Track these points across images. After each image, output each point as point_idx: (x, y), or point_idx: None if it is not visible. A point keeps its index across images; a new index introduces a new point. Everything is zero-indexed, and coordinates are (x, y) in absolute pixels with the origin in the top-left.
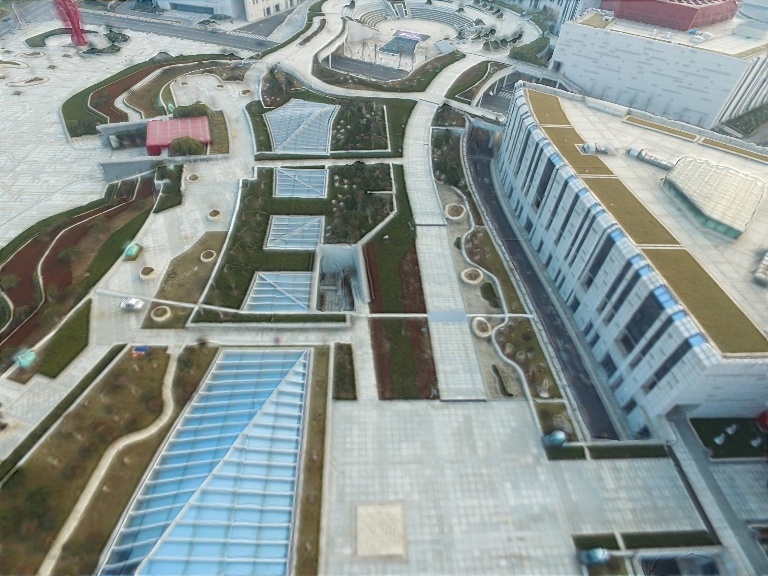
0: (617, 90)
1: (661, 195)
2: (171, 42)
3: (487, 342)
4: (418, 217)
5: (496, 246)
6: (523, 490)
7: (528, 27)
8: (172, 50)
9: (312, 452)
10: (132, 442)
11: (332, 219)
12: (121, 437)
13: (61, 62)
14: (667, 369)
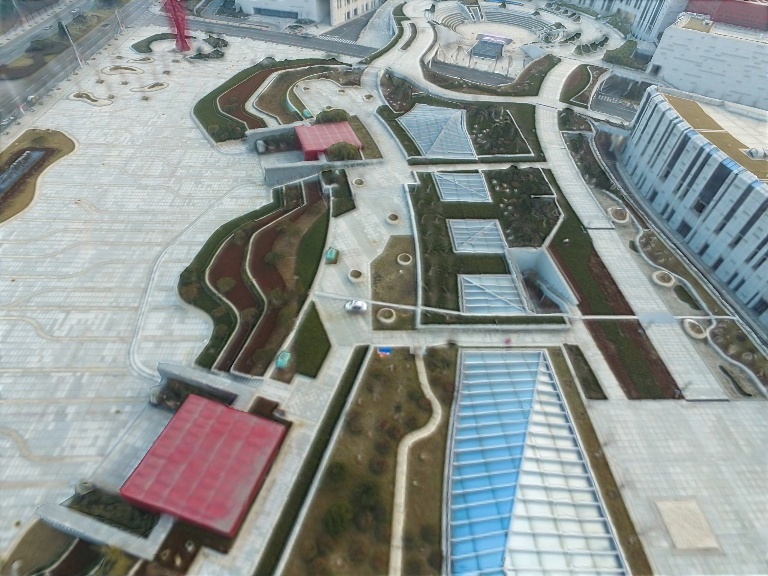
0: (720, 93)
1: None
2: (268, 47)
3: (704, 343)
4: (585, 221)
5: (670, 249)
6: None
7: (607, 30)
8: (272, 55)
9: (592, 450)
10: (418, 439)
11: (507, 223)
12: (406, 435)
13: (173, 67)
14: None
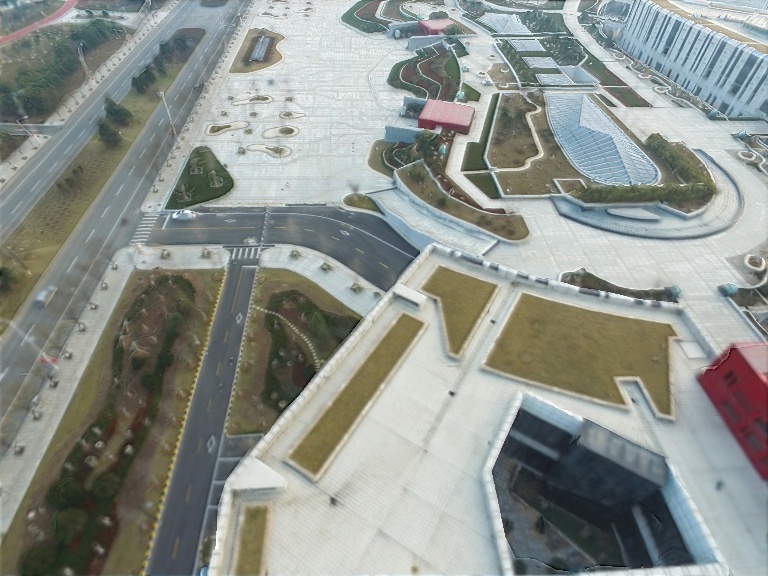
0: None
1: (743, 31)
2: None
3: (665, 95)
4: (600, 59)
5: None
6: (704, 126)
7: None
8: None
9: None
10: None
11: (557, 58)
12: (528, 112)
13: (311, 1)
14: (761, 84)
